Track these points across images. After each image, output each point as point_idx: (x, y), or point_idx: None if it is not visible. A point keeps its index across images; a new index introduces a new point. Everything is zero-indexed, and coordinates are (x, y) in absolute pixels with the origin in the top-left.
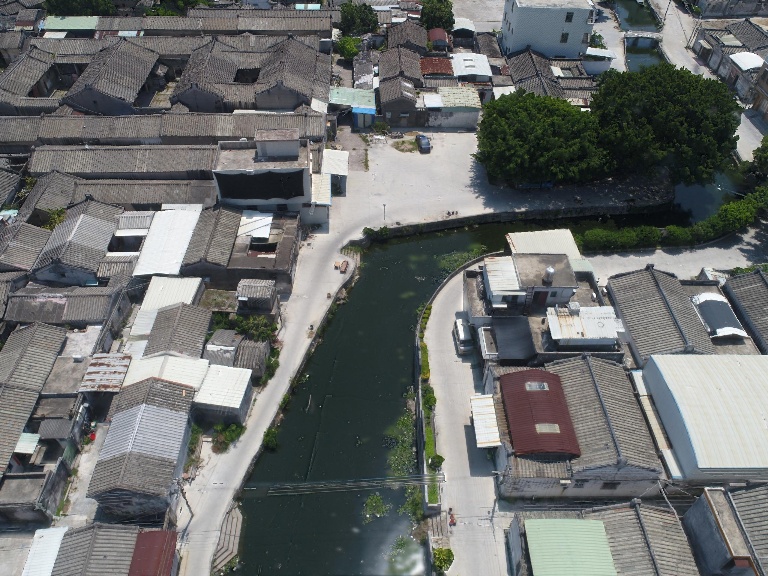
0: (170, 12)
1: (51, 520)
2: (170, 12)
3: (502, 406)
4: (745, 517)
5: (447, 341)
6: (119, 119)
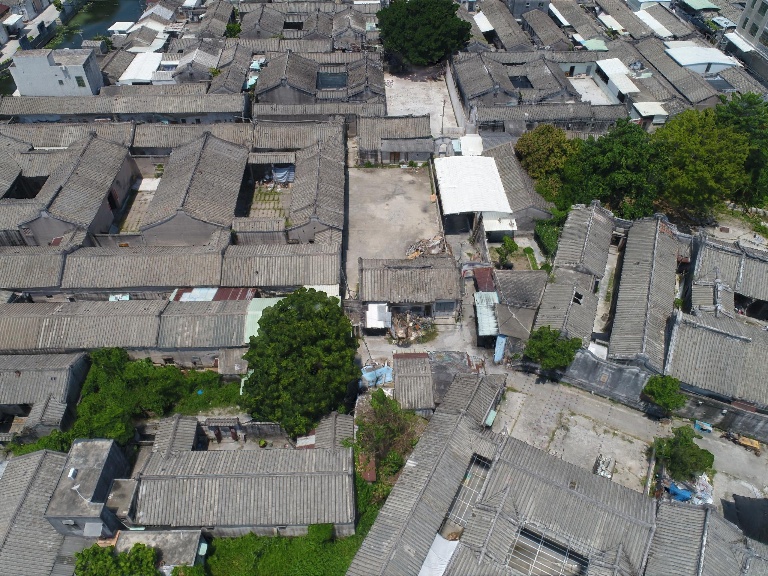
0: (115, 378)
1: None
2: (115, 378)
3: (1, 18)
4: None
5: (4, 59)
6: None
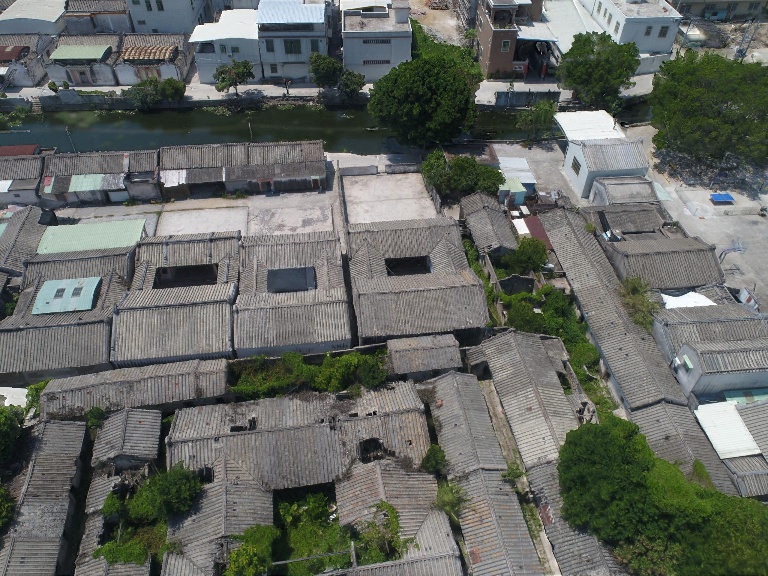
0: None
1: None
2: None
3: None
4: (78, 10)
5: None
6: None
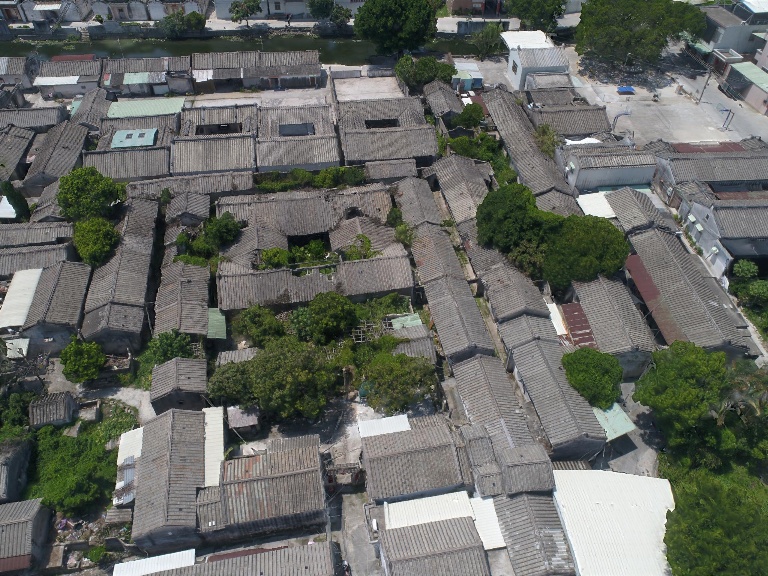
0: None
1: (26, 101)
2: None
3: (44, 2)
4: None
5: None
6: None
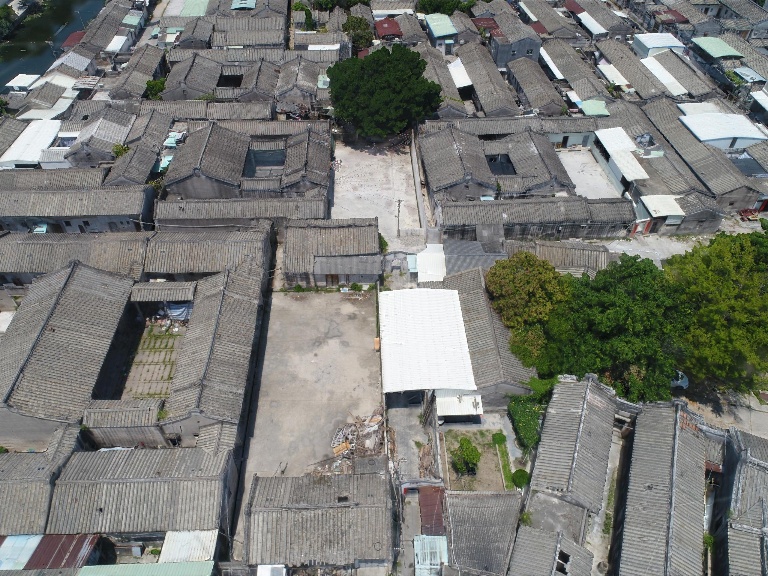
0: None
1: None
2: None
3: None
4: None
5: None
6: (51, 241)
